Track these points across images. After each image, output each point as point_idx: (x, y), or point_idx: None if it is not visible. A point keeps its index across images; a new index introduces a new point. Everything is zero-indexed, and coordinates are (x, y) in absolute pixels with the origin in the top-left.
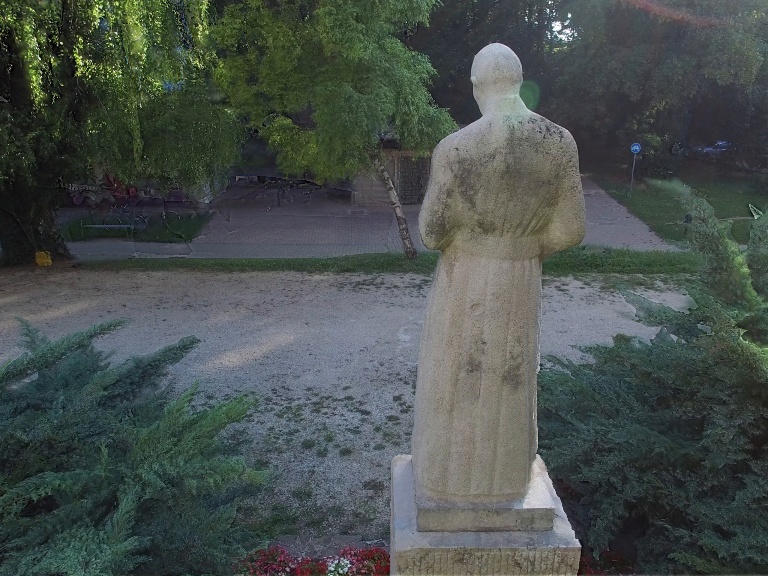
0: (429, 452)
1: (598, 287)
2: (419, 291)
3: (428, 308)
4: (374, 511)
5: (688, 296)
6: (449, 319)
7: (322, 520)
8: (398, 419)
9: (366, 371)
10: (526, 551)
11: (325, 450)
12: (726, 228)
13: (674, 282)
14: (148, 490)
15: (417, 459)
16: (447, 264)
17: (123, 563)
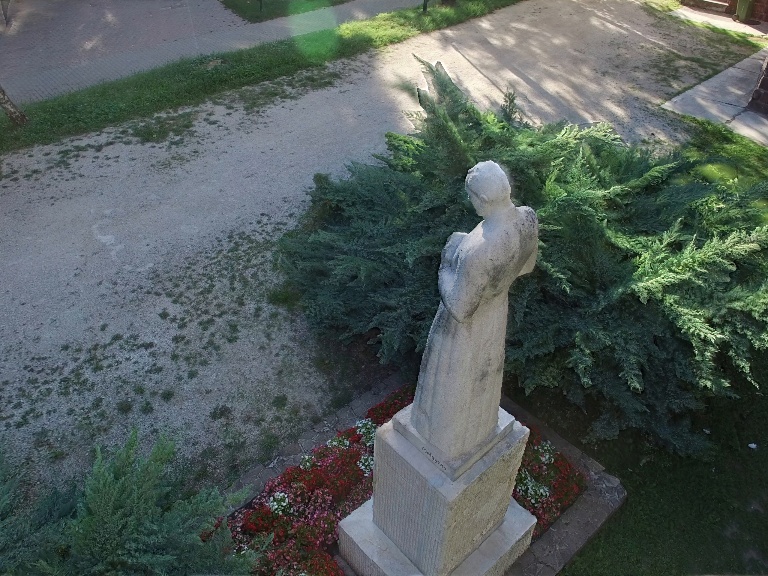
0: (455, 436)
1: (242, 109)
2: (69, 170)
3: (446, 352)
4: (240, 434)
5: (318, 98)
6: (471, 357)
7: (205, 468)
8: (184, 337)
9: (105, 298)
10: (508, 452)
11: (148, 404)
12: (445, 112)
13: (299, 84)
14: (157, 570)
15: (441, 441)
16: (466, 324)
17: None
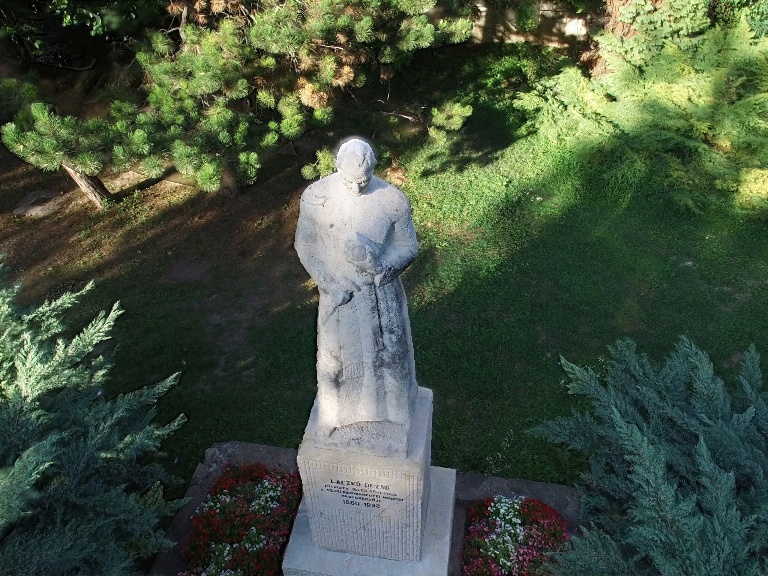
0: None
1: None
2: None
3: None
4: None
5: None
6: None
7: None
8: None
9: None
10: None
11: None
12: None
13: None
14: None
15: None
16: None
17: (643, 536)
